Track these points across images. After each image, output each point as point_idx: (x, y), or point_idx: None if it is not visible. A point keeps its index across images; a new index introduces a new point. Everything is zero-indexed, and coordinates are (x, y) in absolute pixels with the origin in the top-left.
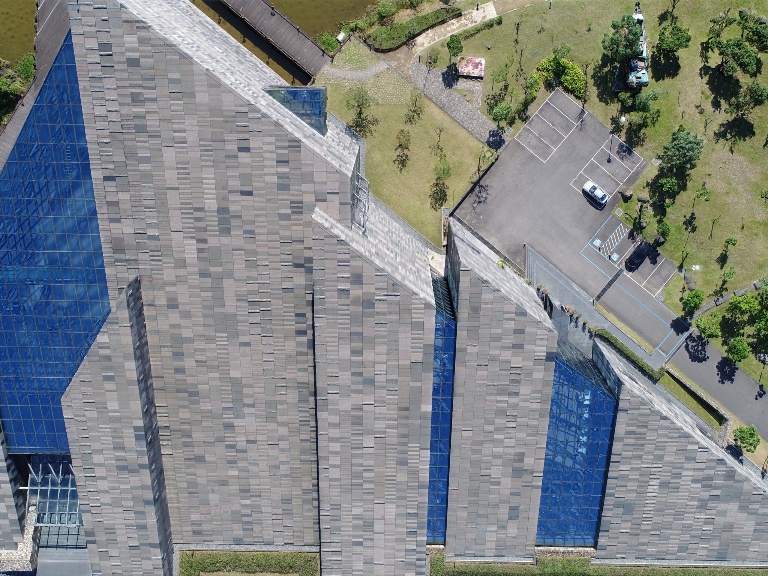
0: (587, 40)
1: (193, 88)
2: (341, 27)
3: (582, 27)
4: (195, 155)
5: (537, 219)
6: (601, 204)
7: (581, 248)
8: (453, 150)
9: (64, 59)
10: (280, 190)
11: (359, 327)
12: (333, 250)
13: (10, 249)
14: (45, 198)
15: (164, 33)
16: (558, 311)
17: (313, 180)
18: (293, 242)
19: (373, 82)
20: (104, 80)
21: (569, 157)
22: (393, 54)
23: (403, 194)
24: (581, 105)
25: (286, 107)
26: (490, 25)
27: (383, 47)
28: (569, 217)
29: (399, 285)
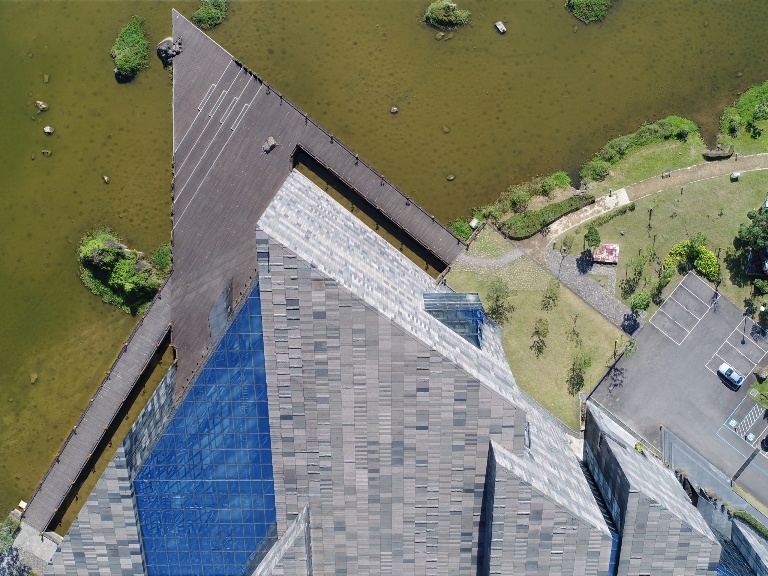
0: (719, 224)
1: (377, 337)
2: (474, 213)
3: (714, 211)
4: (373, 395)
5: (673, 401)
6: (737, 386)
7: (717, 429)
8: (589, 335)
9: (249, 311)
10: (455, 425)
11: (535, 557)
12: (515, 490)
13: (179, 479)
14: (218, 433)
15: (349, 285)
16: (703, 501)
17: (489, 415)
18: (465, 470)
19: (508, 269)
20: (289, 331)
21: (703, 339)
22: (528, 241)
23: (540, 380)
24: (714, 288)
25: (446, 325)
26: (623, 211)
27: (518, 235)
28: (704, 398)
29: (578, 520)
